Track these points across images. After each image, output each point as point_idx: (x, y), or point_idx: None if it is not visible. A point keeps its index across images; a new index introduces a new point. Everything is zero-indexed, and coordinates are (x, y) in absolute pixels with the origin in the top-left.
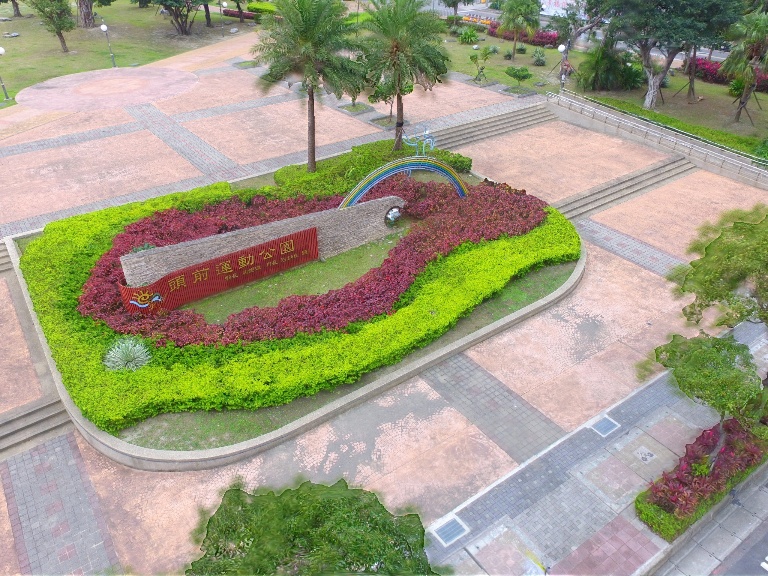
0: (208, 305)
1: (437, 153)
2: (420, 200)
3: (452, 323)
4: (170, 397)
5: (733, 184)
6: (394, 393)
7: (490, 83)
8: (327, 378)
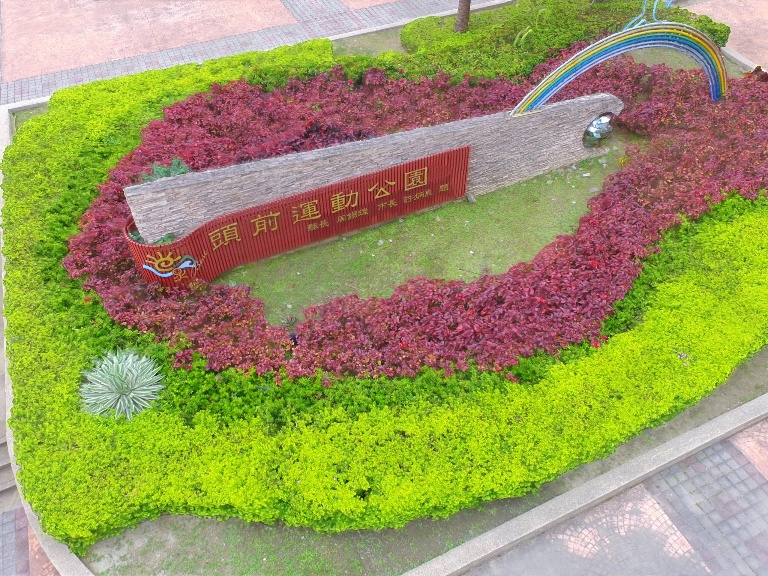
0: (277, 269)
1: (667, 11)
2: (637, 97)
3: (719, 383)
4: (180, 498)
5: None
6: (597, 522)
7: None
8: (476, 494)
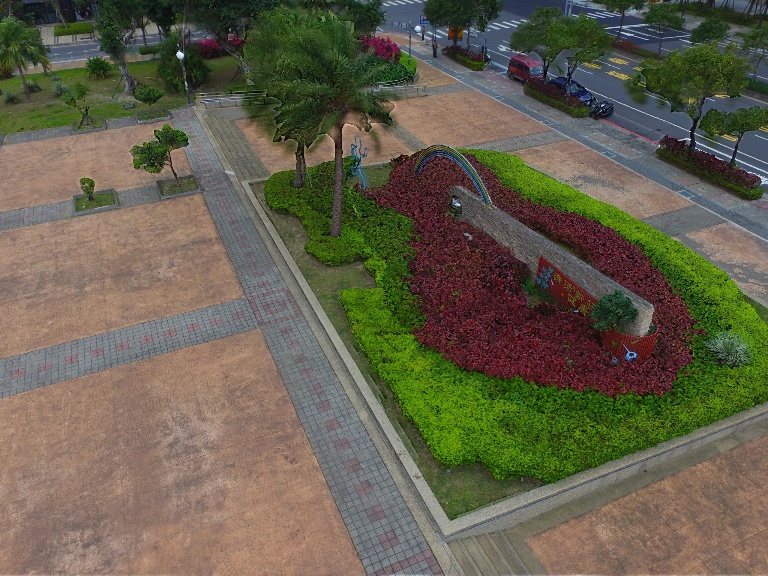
0: None
1: (325, 168)
2: None
3: None
4: (766, 325)
5: (401, 102)
6: None
7: (104, 122)
8: None
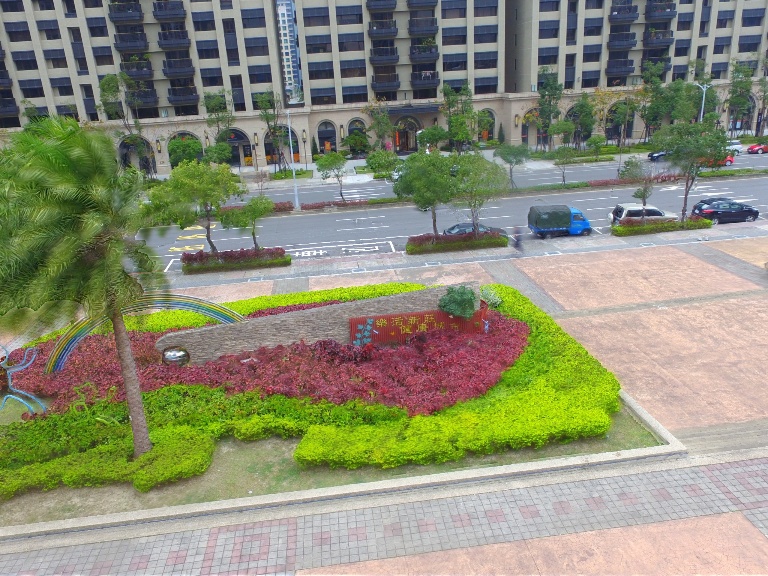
0: None
1: None
2: None
3: None
4: None
5: None
6: None
7: None
8: None
